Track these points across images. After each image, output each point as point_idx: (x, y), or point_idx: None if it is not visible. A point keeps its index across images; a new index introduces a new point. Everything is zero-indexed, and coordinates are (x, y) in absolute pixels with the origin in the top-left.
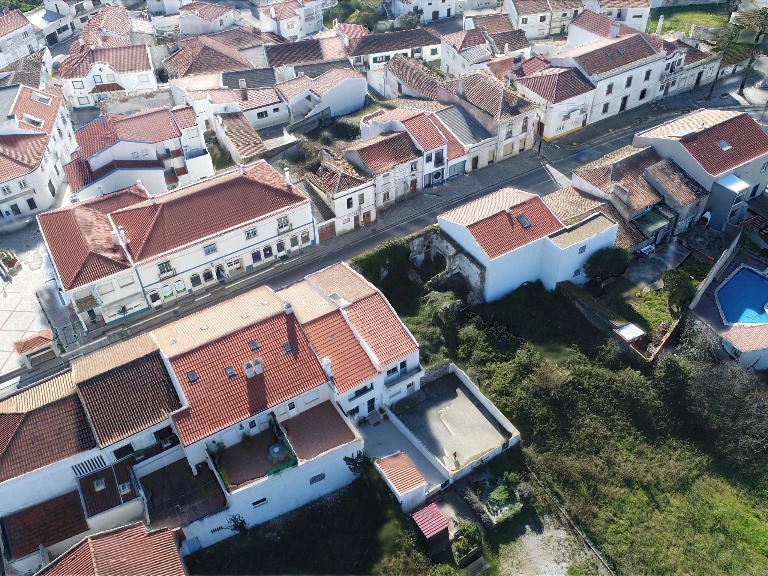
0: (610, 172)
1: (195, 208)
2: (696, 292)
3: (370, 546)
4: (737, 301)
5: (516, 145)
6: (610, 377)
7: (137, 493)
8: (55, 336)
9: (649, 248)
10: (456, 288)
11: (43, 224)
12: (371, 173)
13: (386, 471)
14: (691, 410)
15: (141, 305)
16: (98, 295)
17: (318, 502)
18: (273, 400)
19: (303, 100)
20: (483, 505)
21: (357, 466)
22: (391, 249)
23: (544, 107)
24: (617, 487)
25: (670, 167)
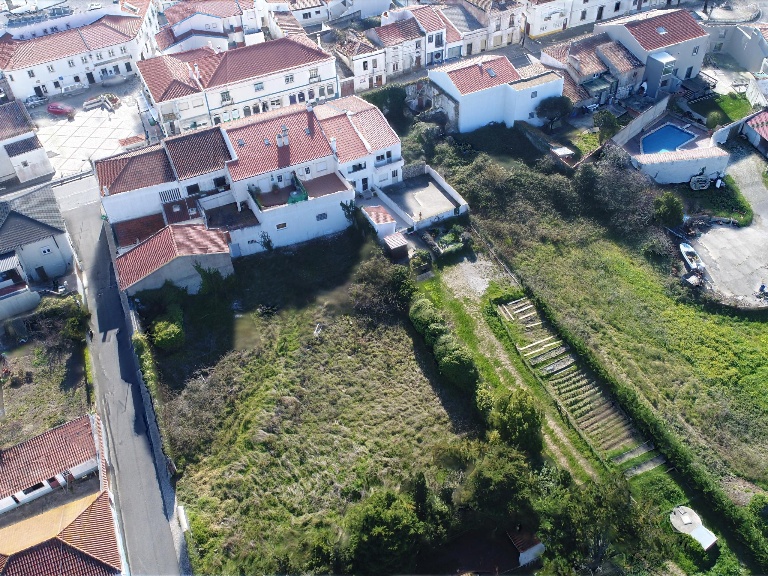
0: (569, 49)
1: (250, 57)
2: (620, 130)
3: (354, 259)
4: (657, 144)
5: (505, 38)
6: (542, 177)
7: (201, 215)
8: (147, 137)
9: (594, 106)
10: (438, 122)
11: (140, 67)
12: (384, 45)
13: (369, 213)
14: (597, 198)
15: (207, 125)
16: (178, 111)
17: (322, 238)
18: (295, 161)
19: (340, 5)
20: (436, 243)
21: (350, 214)
22: (391, 90)
23: (530, 9)
24: (534, 242)
25: (617, 46)
